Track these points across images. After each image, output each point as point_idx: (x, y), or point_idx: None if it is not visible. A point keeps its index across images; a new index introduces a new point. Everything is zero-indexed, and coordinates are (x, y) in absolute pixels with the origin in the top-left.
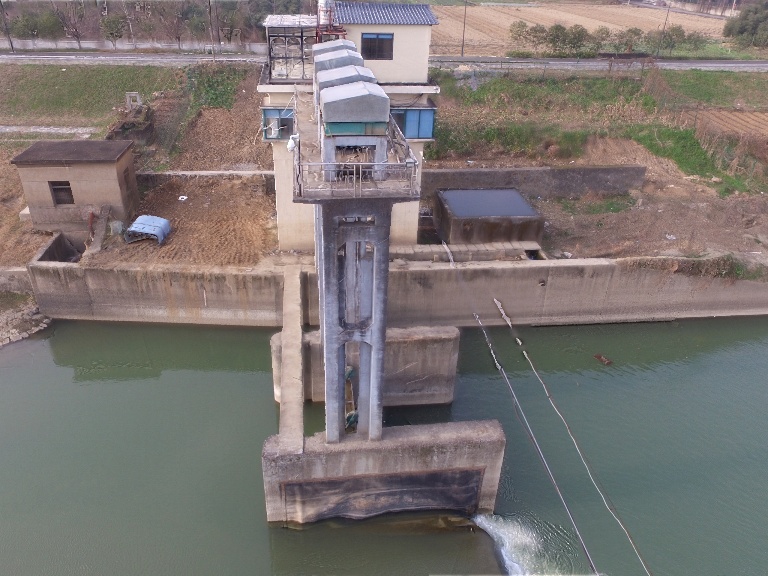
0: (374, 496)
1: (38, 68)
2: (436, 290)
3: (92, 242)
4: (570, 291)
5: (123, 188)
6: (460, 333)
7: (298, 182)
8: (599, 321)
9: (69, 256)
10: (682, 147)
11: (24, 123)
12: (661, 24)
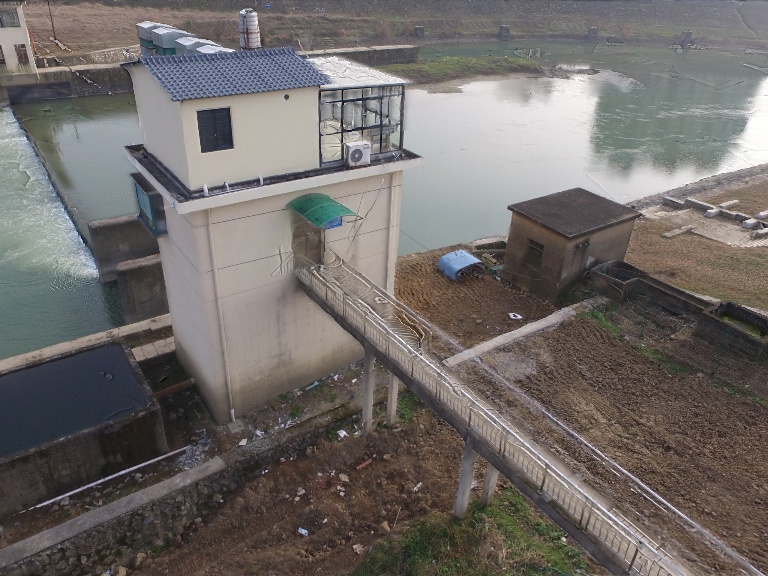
0: None
1: None
2: None
3: None
4: None
5: (518, 247)
6: None
7: None
8: None
9: None
10: None
11: None
12: None
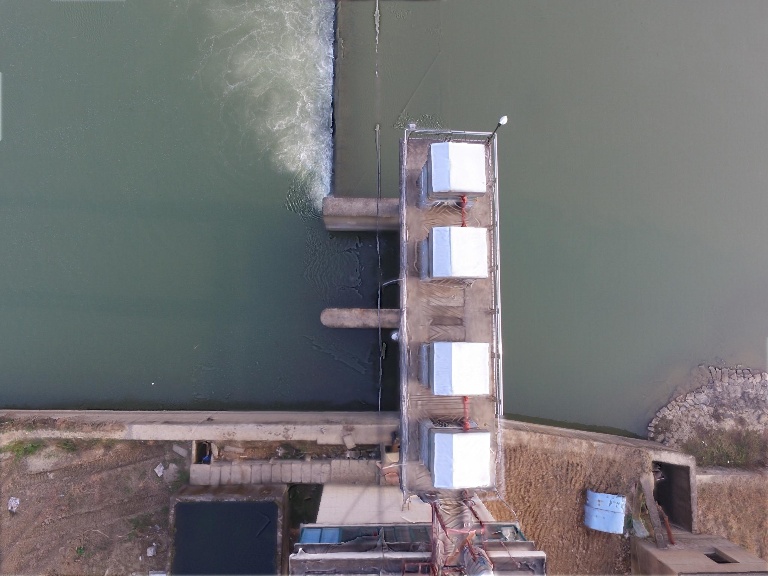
0: None
1: None
2: None
3: None
4: None
5: (658, 572)
6: None
7: None
8: None
9: (671, 519)
10: None
11: None
12: None
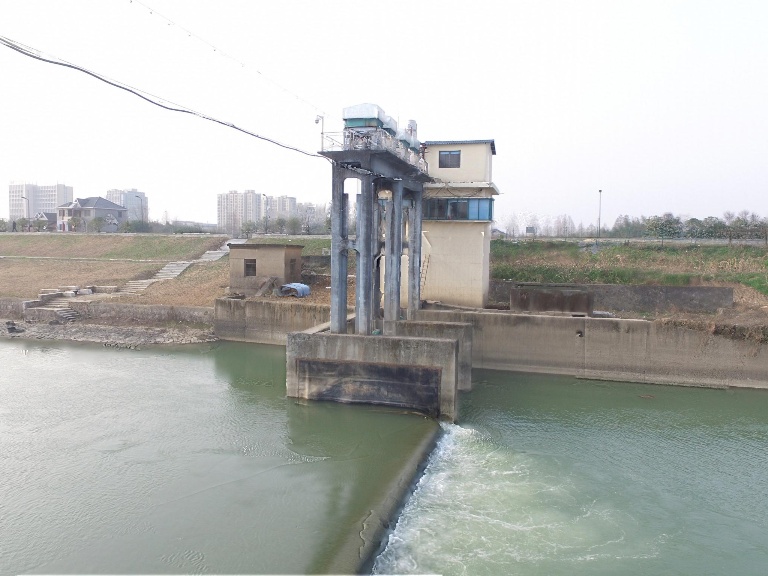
0: (359, 383)
1: (275, 240)
2: (486, 332)
3: None
4: (608, 345)
5: (288, 268)
6: None
7: (322, 143)
8: (644, 380)
9: None
10: None
11: None
12: None
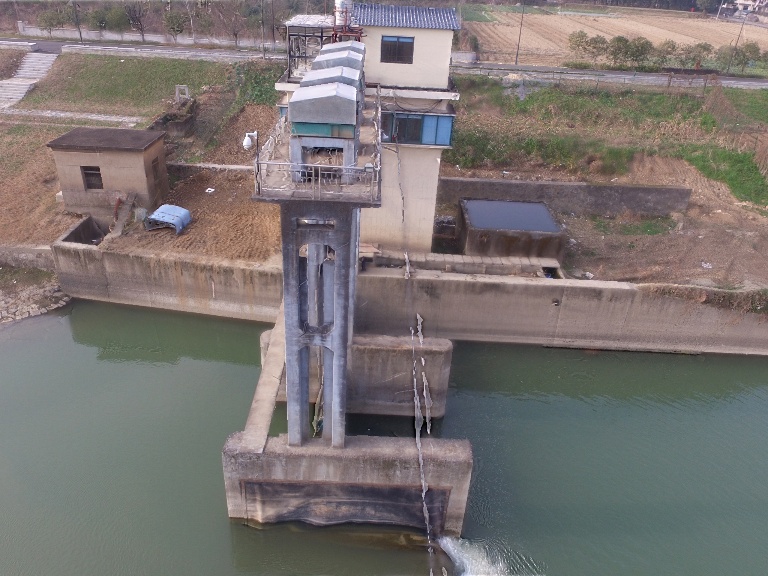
0: (335, 504)
1: (99, 58)
2: (443, 301)
3: (116, 227)
4: (586, 313)
5: (150, 177)
6: (467, 347)
7: (257, 180)
8: (617, 348)
9: (96, 239)
10: (738, 171)
11: (78, 109)
12: (734, 40)
